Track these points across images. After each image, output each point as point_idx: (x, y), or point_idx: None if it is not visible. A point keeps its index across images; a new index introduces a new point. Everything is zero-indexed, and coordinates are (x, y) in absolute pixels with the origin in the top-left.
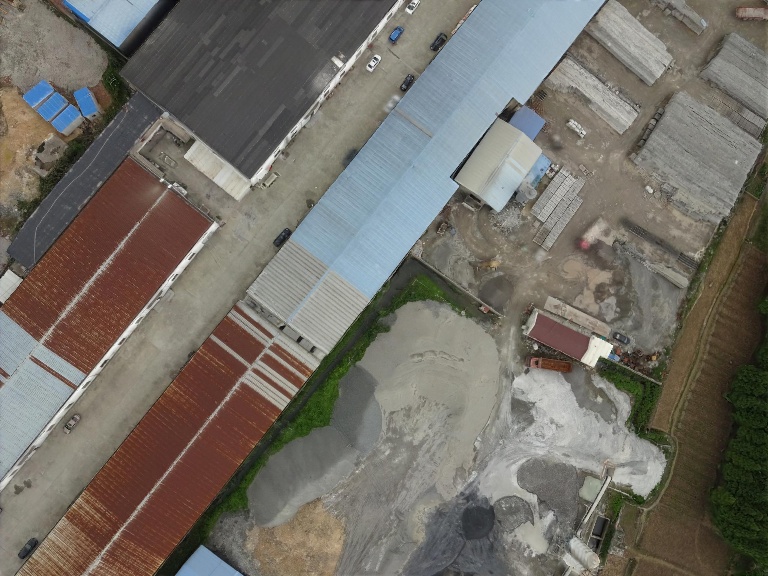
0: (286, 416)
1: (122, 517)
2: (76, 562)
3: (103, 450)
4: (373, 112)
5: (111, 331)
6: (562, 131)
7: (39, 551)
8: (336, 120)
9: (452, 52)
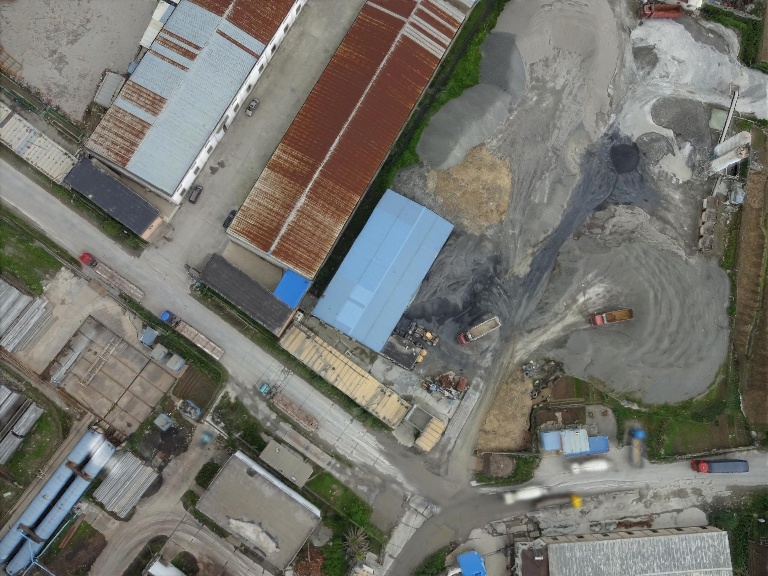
0: (438, 82)
1: (318, 159)
2: (284, 202)
3: (283, 129)
4: None
5: (281, 6)
6: None
7: (249, 199)
8: None
9: None
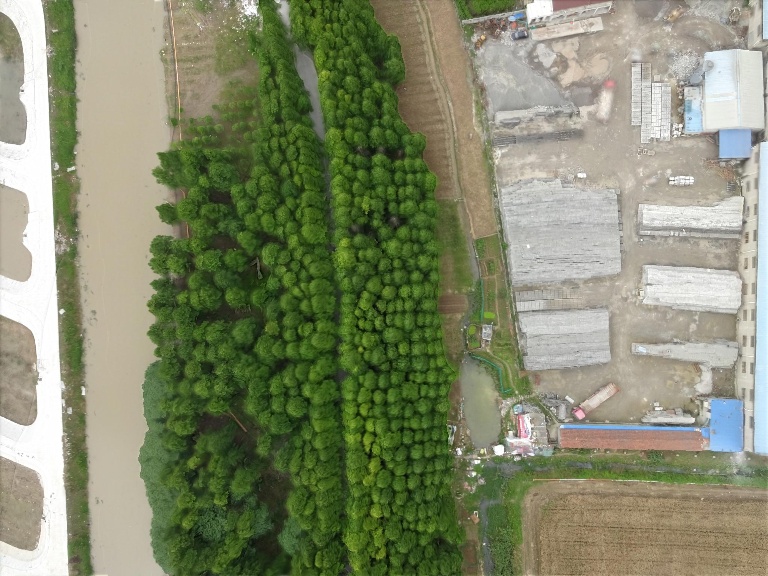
0: None
1: None
2: None
3: None
4: None
5: None
6: (691, 171)
7: None
8: None
9: None
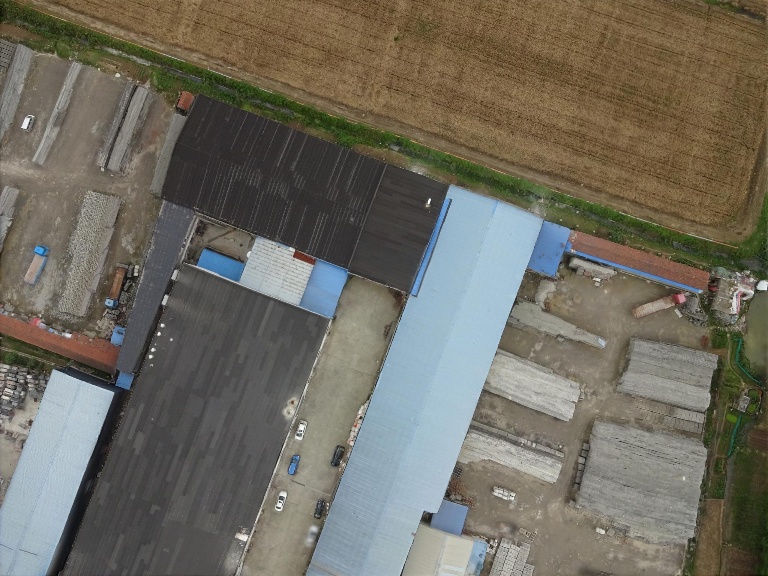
0: None
1: None
2: None
3: None
4: (296, 549)
5: None
6: (490, 500)
7: None
8: (263, 569)
9: (349, 487)
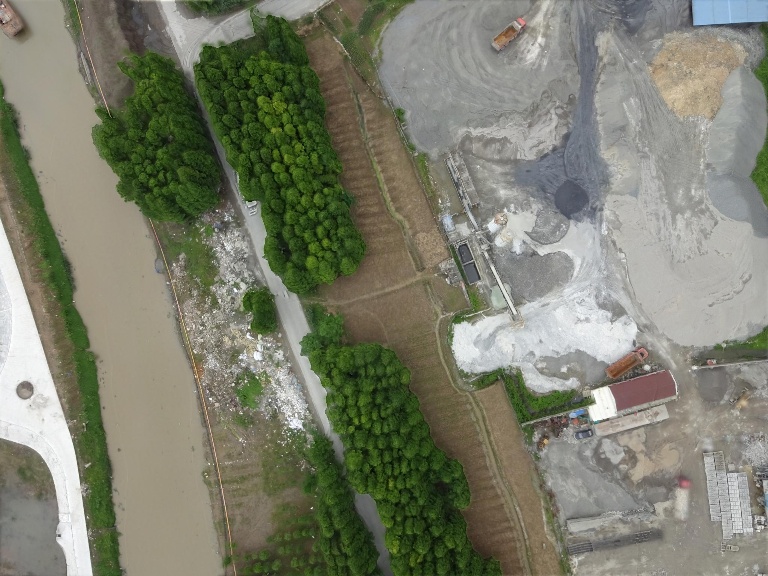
0: None
1: None
2: None
3: None
4: None
5: None
6: None
7: None
8: None
9: None
